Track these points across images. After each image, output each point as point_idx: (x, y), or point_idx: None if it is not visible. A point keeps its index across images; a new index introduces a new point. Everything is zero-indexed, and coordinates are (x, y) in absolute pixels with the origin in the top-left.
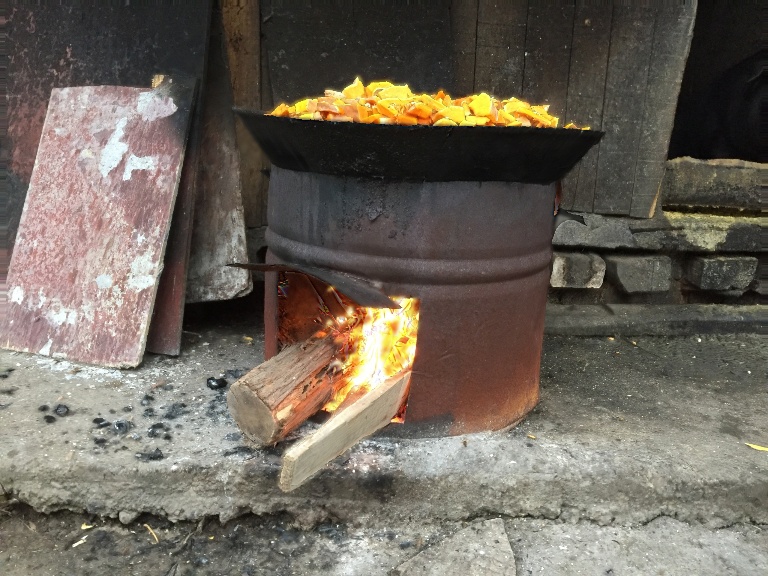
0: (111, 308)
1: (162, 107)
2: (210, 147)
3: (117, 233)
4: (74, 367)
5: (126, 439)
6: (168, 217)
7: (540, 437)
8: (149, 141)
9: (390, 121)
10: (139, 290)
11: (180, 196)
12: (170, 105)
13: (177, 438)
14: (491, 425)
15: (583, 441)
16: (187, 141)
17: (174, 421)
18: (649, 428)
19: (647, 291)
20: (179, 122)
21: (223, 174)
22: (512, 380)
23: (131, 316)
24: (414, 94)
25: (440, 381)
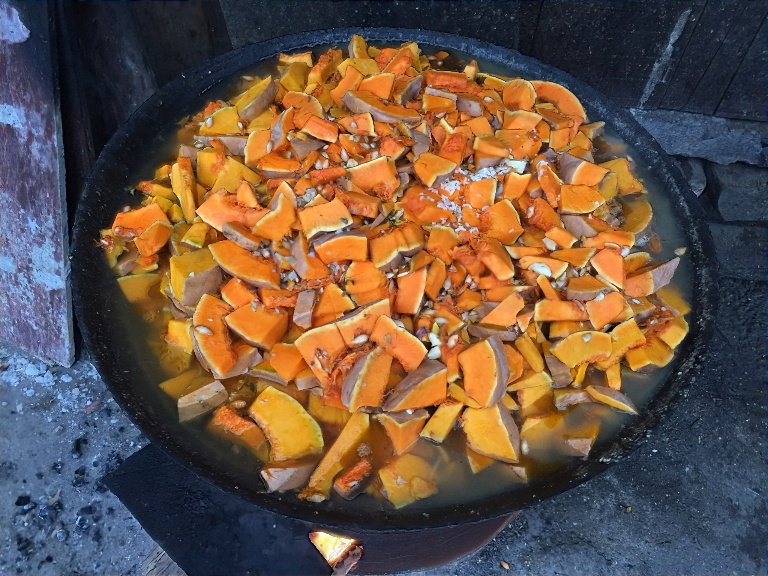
0: (23, 298)
1: (6, 23)
2: (108, 56)
3: (1, 207)
4: (0, 357)
5: (52, 539)
6: (60, 207)
7: (516, 563)
8: (3, 80)
9: (315, 380)
10: (49, 289)
11: (72, 168)
12: (17, 23)
13: (107, 538)
14: (458, 559)
15: (565, 570)
16: (59, 91)
17: (106, 498)
18: (655, 533)
19: (752, 220)
20: (38, 60)
21: (136, 100)
22: (490, 533)
23: (48, 315)
24: (402, 148)
25: (394, 562)
